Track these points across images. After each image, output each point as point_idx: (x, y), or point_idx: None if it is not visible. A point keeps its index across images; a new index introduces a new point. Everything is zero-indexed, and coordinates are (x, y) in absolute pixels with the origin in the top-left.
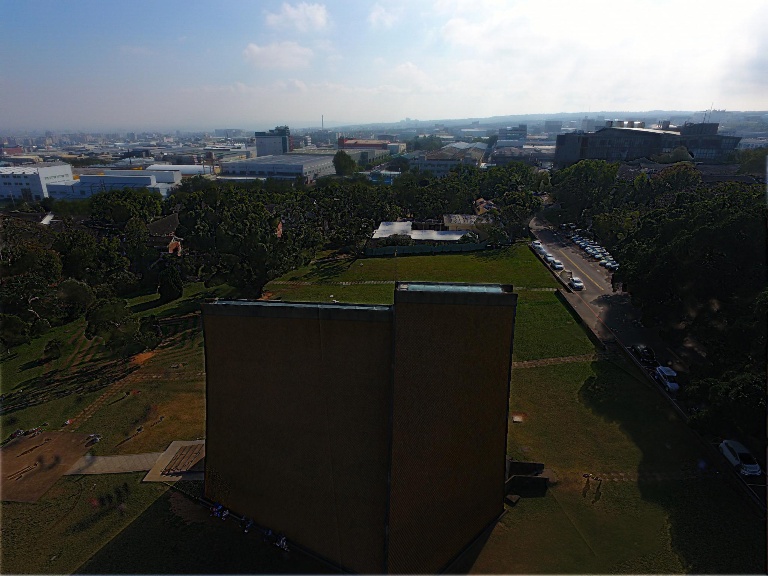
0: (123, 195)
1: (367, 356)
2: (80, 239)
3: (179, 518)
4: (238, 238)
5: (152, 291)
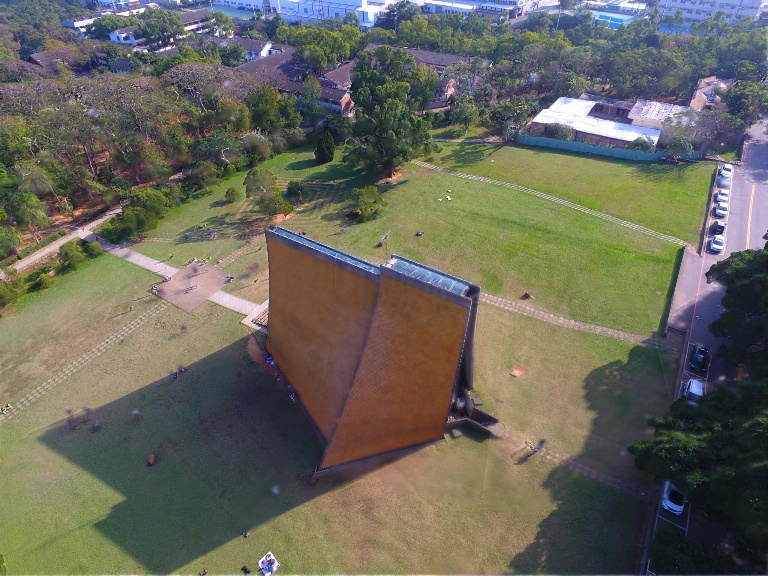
0: (318, 37)
1: (363, 302)
2: (265, 95)
3: (248, 355)
4: (372, 123)
5: (315, 148)
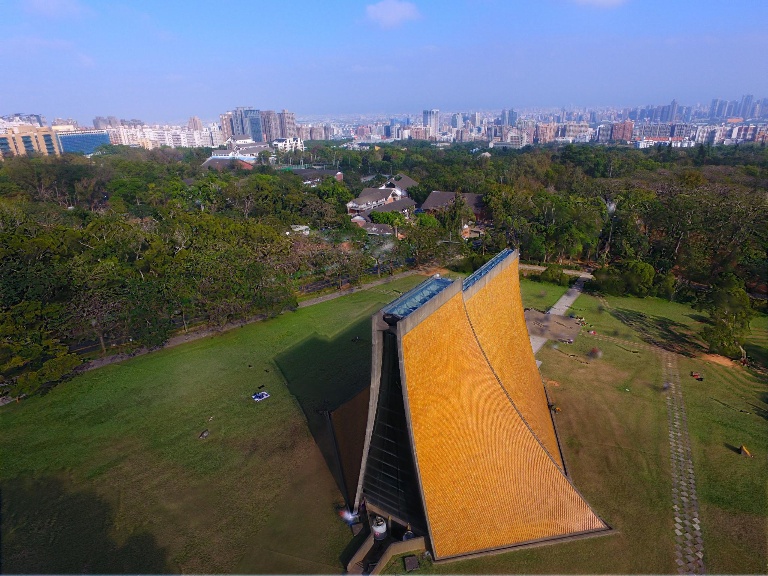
0: None
1: None
2: None
3: None
4: None
5: None
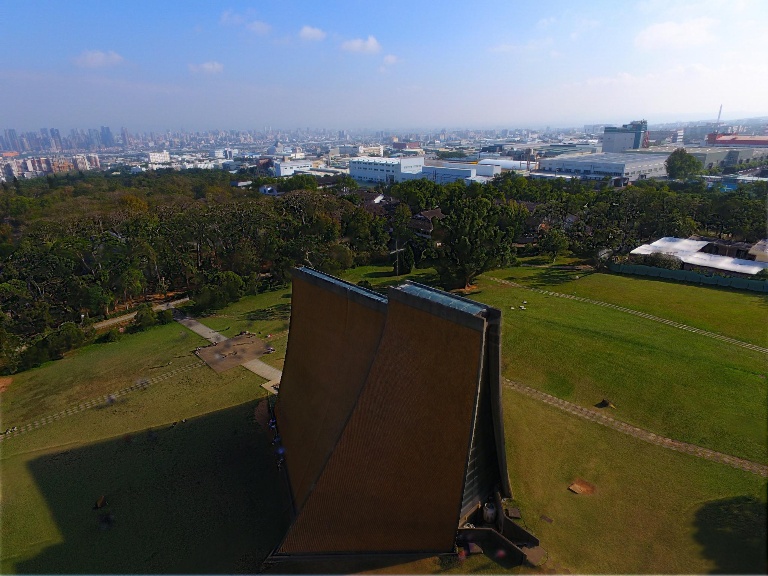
0: (421, 184)
1: (371, 342)
2: (358, 215)
3: (254, 416)
4: (446, 229)
5: None
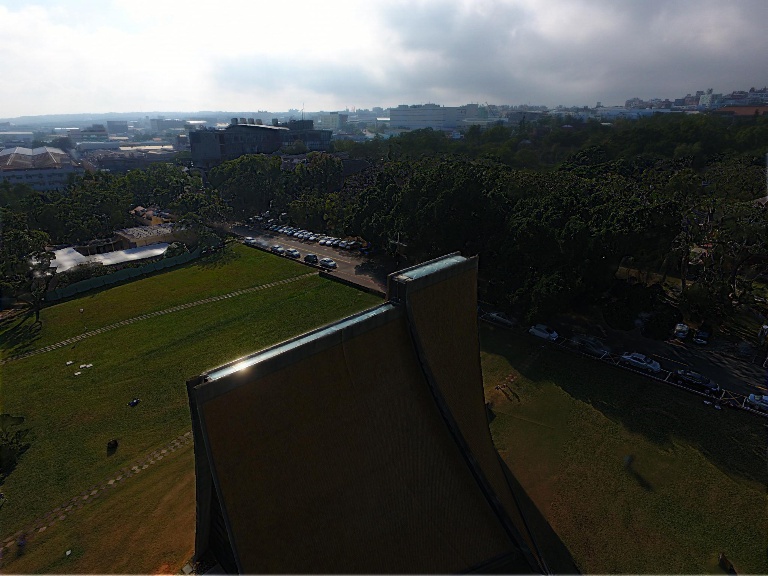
0: None
1: (390, 361)
2: None
3: None
4: None
5: None
